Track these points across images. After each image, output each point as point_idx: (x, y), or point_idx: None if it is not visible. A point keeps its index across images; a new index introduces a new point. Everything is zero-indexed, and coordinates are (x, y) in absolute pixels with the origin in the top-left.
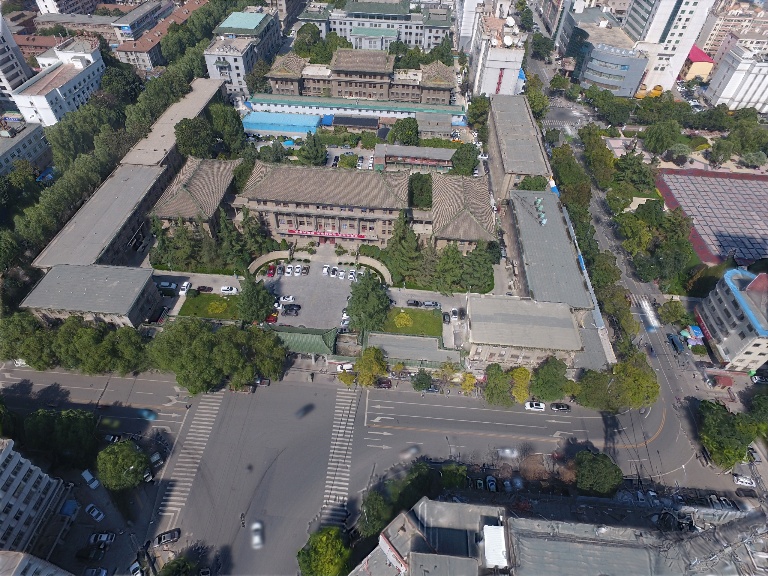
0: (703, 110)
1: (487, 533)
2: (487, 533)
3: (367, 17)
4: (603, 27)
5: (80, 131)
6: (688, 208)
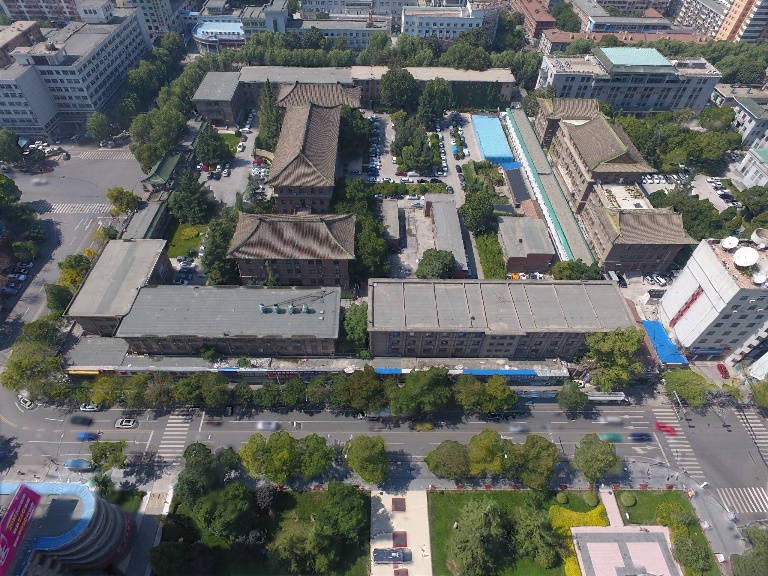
0: None
1: None
2: None
3: None
4: None
5: (395, 47)
6: None
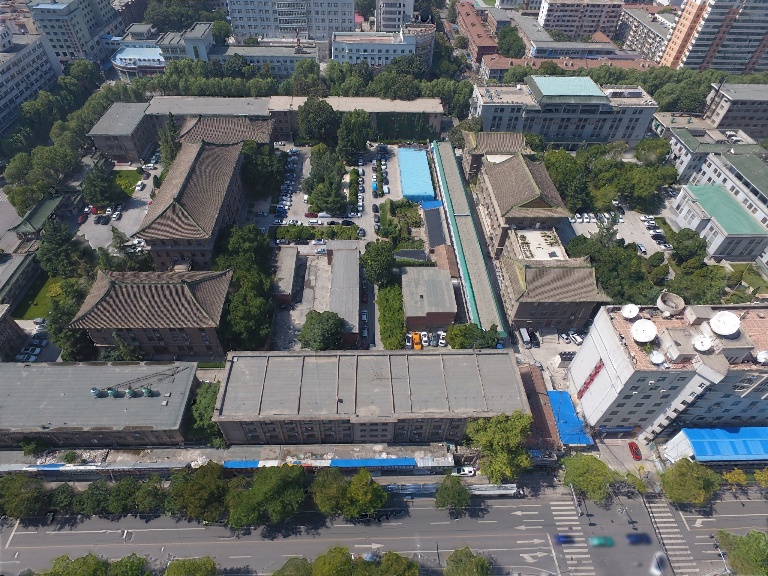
0: None
1: None
2: None
3: (750, 187)
4: None
5: None
6: None
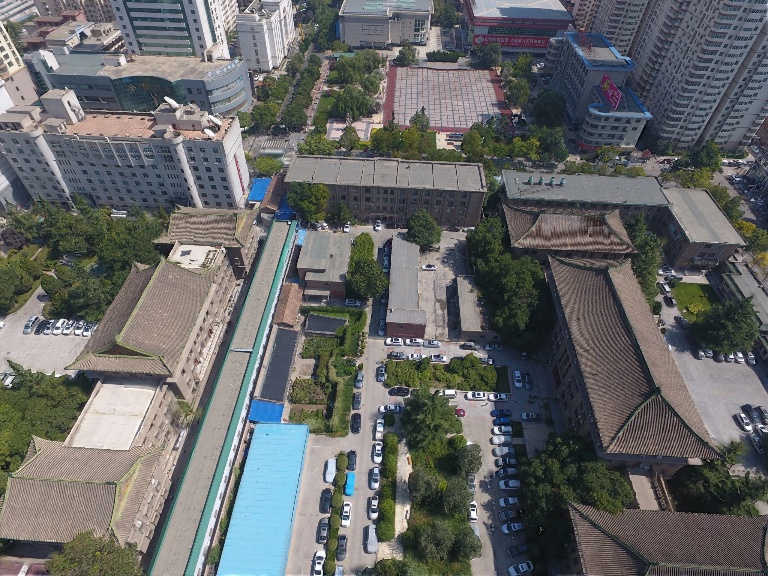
0: (278, 77)
1: None
2: None
3: None
4: (125, 64)
5: None
6: (445, 124)
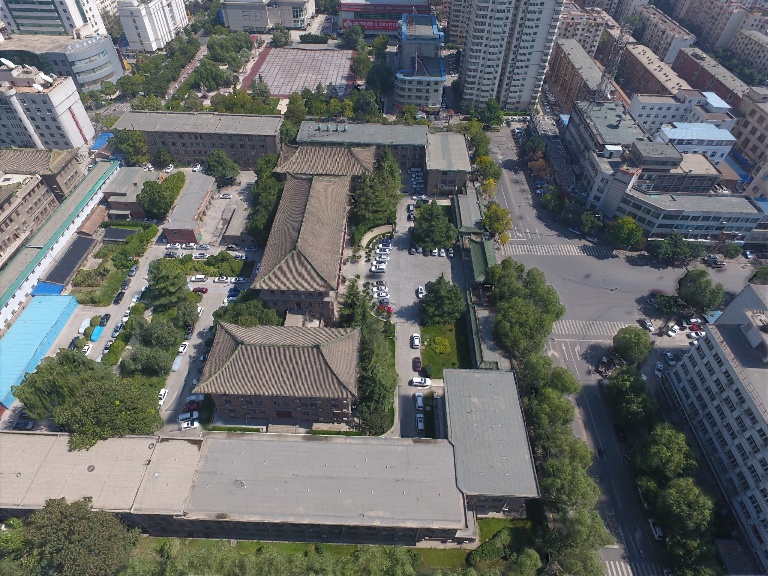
0: None
1: (611, 149)
2: (611, 149)
3: None
4: (3, 41)
5: None
6: None
